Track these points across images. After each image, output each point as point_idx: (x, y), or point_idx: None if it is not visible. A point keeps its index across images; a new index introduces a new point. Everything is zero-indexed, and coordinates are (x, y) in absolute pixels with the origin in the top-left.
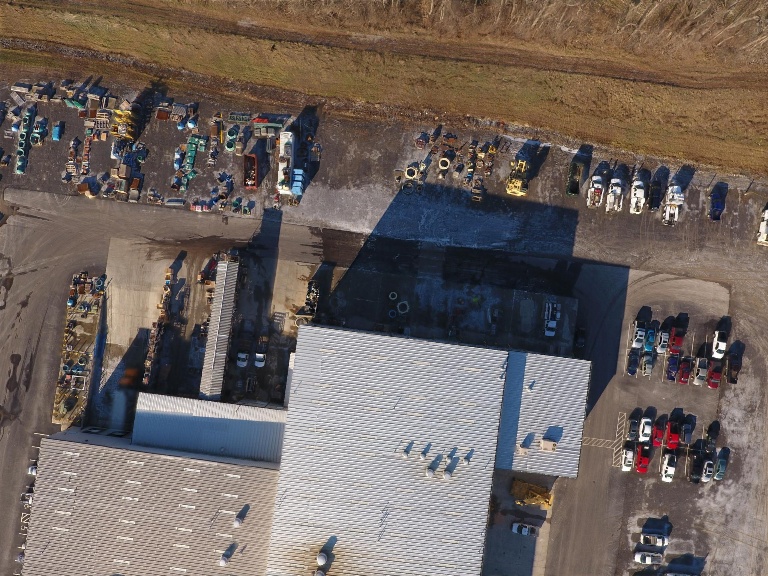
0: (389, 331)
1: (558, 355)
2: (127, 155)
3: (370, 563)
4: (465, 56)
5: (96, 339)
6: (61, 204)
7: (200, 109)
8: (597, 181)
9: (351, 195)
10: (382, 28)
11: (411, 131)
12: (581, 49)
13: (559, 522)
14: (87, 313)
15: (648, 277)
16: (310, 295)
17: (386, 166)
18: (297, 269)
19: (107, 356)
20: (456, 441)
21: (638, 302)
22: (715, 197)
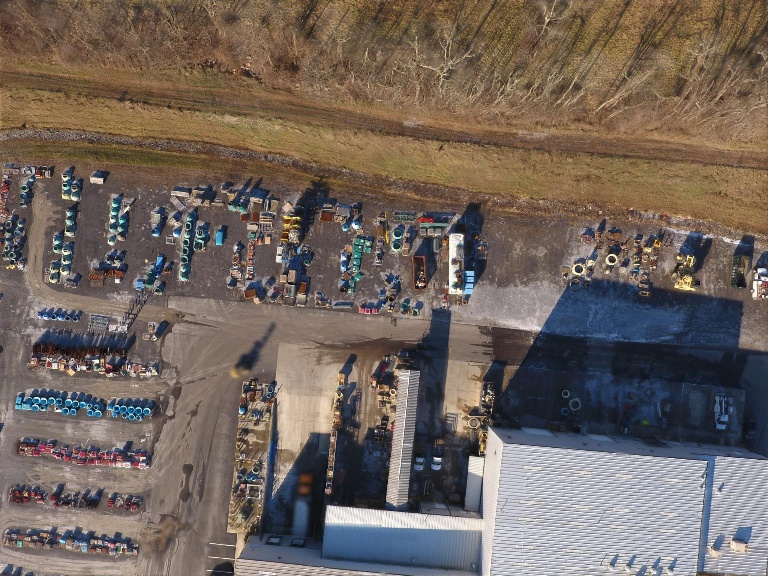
0: (565, 431)
1: (731, 449)
2: (293, 259)
3: None
4: (632, 152)
5: (269, 447)
6: (227, 310)
7: (364, 209)
8: (763, 273)
9: (519, 293)
10: (549, 125)
11: (576, 226)
12: (746, 143)
13: None
14: (259, 421)
15: None
16: (486, 397)
17: (552, 262)
18: (468, 369)
19: (278, 462)
20: (659, 552)
21: None
22: None
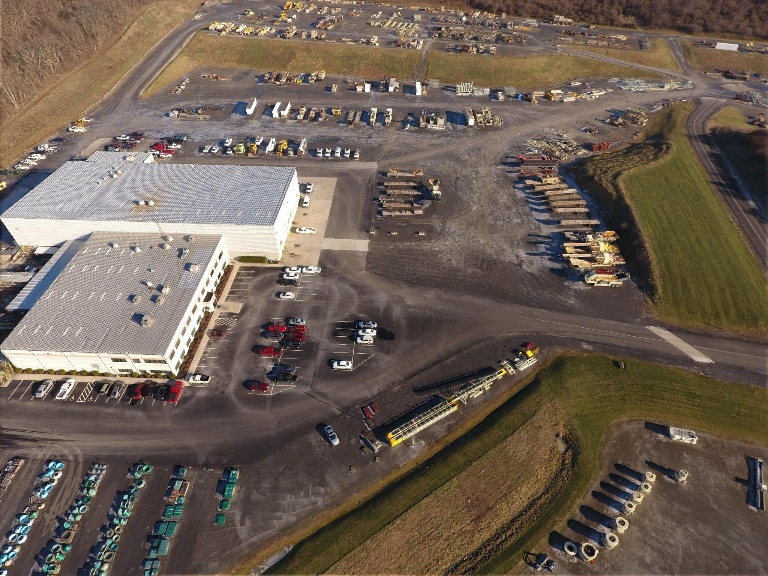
0: None
1: None
2: None
3: None
4: None
5: None
6: None
7: None
8: None
9: None
10: None
11: None
12: None
13: None
14: None
15: None
16: (2, 249)
17: None
18: None
19: None
20: None
21: None
22: (53, 140)
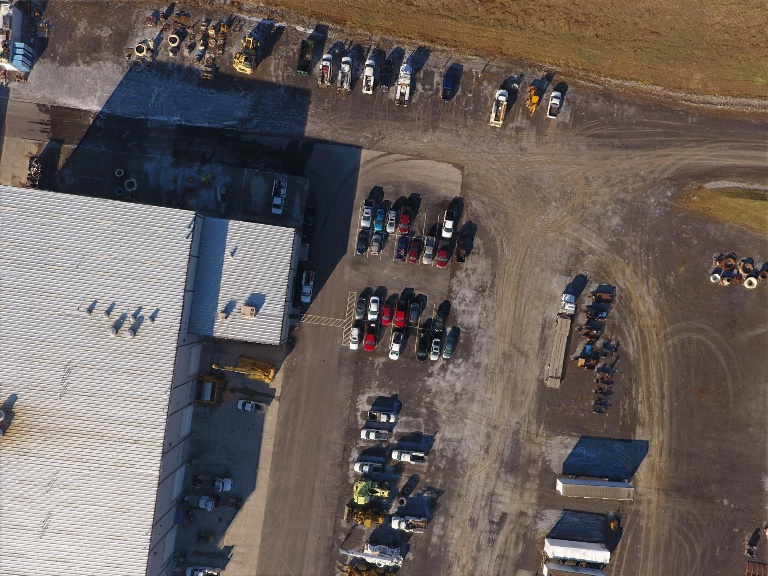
0: None
1: None
2: None
3: (51, 421)
4: None
5: None
6: None
7: None
8: (327, 59)
9: (80, 72)
10: None
11: (143, 8)
12: None
13: (288, 400)
14: None
15: (380, 157)
16: (31, 170)
17: (117, 43)
18: (24, 146)
19: None
20: (141, 300)
21: (370, 182)
22: (446, 77)
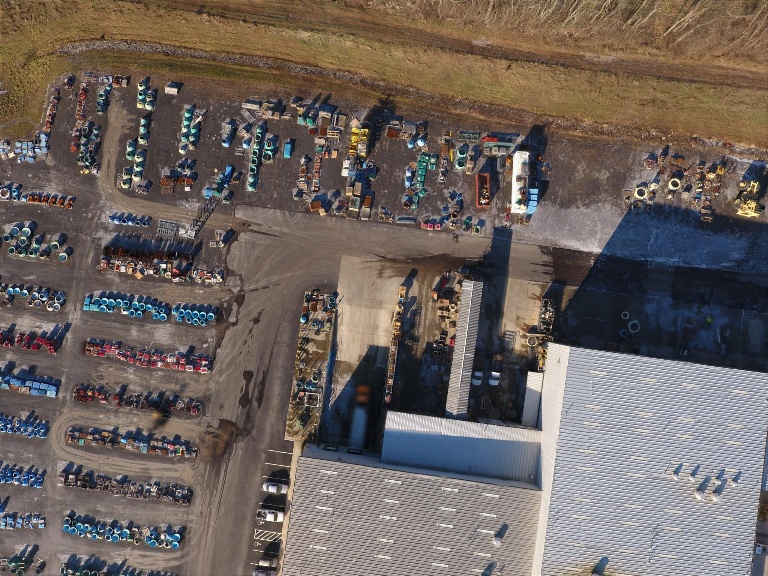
0: (625, 351)
1: None
2: (358, 173)
3: None
4: (698, 77)
5: (329, 356)
6: (292, 221)
7: (429, 127)
8: None
9: (580, 214)
10: (616, 49)
11: (639, 151)
12: None
13: None
14: (320, 330)
15: None
16: (546, 314)
17: (615, 186)
18: (528, 288)
19: (337, 373)
20: (724, 463)
21: None
22: None
